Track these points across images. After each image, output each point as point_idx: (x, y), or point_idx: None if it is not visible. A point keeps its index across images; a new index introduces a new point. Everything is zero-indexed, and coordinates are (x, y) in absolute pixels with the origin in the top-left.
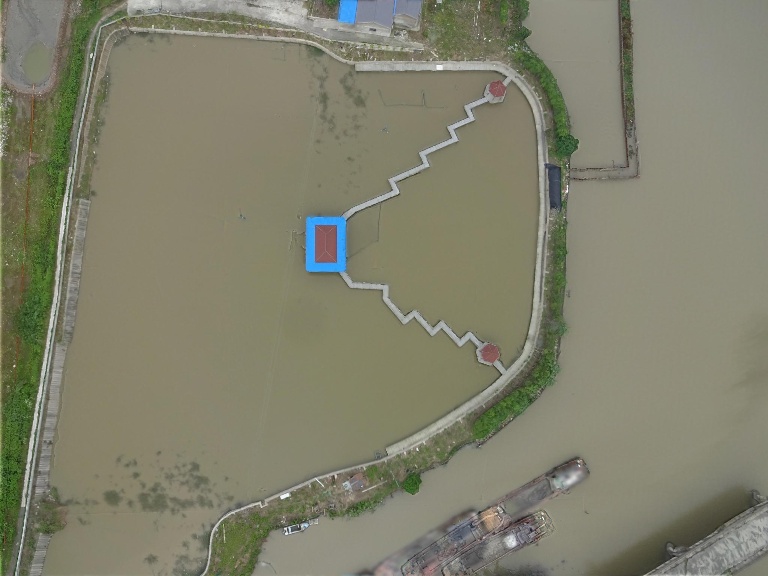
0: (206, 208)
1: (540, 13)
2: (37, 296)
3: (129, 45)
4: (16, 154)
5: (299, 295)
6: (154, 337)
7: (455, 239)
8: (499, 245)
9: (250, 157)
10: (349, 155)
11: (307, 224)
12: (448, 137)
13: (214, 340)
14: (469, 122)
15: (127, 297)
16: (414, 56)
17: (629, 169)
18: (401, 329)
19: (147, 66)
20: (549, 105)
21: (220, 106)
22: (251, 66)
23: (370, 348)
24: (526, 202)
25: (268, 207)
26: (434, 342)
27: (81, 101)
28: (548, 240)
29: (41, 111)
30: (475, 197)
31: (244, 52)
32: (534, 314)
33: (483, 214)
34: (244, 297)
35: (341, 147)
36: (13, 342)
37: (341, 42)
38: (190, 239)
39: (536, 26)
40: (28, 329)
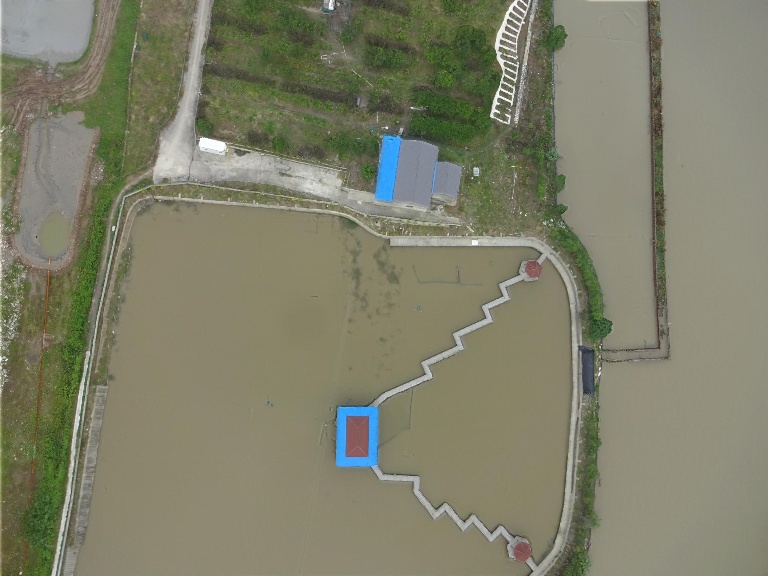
0: (232, 395)
1: (574, 183)
2: (48, 496)
3: (153, 214)
4: (28, 335)
5: (327, 489)
6: (173, 537)
7: (487, 424)
8: (531, 431)
9: (280, 341)
10: (381, 335)
11: (338, 415)
12: (482, 316)
13: (238, 542)
14: (504, 302)
15: (145, 491)
16: (450, 231)
17: (660, 350)
18: (431, 523)
19: (172, 237)
20: (584, 285)
21: (249, 284)
22: (282, 238)
23: (399, 544)
24: (559, 385)
25: (297, 394)
26: (465, 536)
27: (101, 278)
28: (581, 427)
29: (57, 288)
30: (508, 380)
31: (275, 223)
32: (566, 505)
33: (516, 398)
34: (271, 495)
35: (373, 327)
36: (20, 546)
37: (376, 216)
38: (214, 430)
39: (570, 197)
40: (37, 533)
